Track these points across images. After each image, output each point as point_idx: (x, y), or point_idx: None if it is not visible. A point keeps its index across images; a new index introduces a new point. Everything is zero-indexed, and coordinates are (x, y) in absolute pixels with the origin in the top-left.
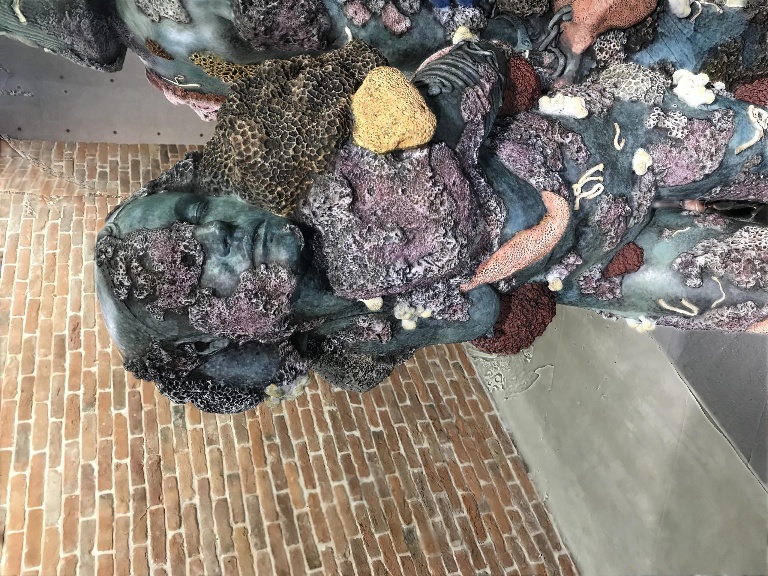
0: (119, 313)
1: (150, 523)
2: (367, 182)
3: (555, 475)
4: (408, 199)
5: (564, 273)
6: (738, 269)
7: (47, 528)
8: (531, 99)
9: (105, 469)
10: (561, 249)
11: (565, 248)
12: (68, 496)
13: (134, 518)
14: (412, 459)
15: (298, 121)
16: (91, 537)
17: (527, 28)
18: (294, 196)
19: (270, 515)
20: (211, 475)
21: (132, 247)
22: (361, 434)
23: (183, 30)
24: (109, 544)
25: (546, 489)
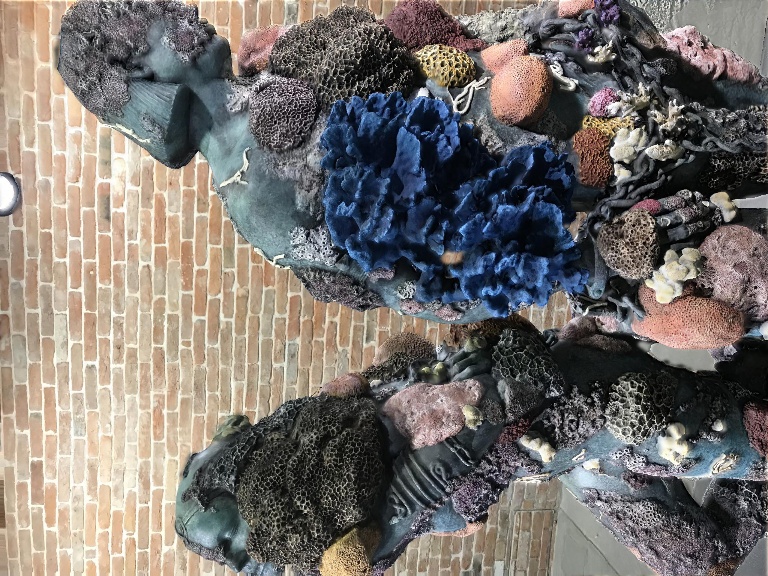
0: None
1: None
2: None
3: None
4: None
5: None
6: (616, 522)
7: None
8: None
9: None
10: None
11: None
12: None
13: None
14: None
15: None
16: None
17: (610, 275)
18: None
19: None
20: None
21: None
22: None
23: None
24: None
25: None
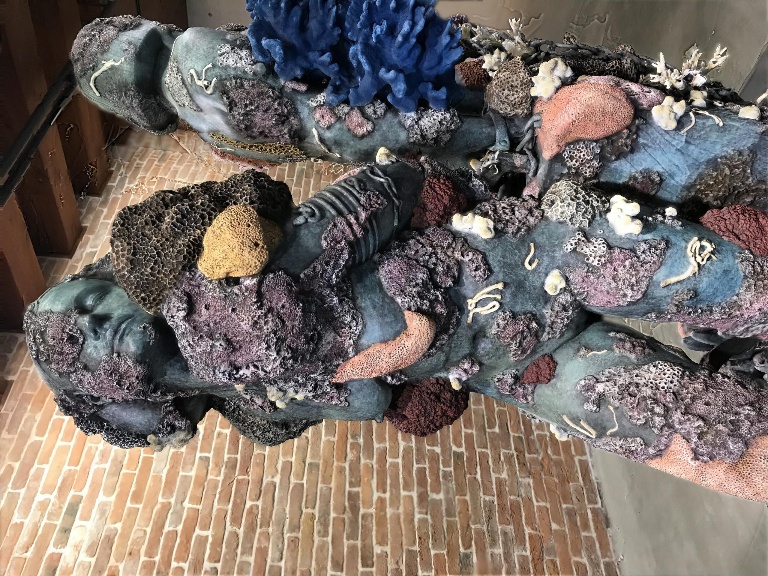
0: (36, 366)
1: (235, 490)
2: (205, 299)
3: (633, 538)
4: (237, 317)
5: (463, 375)
6: (632, 404)
7: (154, 474)
8: (448, 214)
9: (208, 434)
10: (457, 354)
11: (461, 354)
12: (175, 451)
13: (223, 482)
14: (486, 486)
15: (160, 246)
16: (185, 490)
17: (509, 127)
18: (157, 300)
19: (338, 508)
20: (295, 459)
21: (38, 324)
22: (441, 451)
23: (200, 115)
24: (198, 500)
25: (622, 550)
